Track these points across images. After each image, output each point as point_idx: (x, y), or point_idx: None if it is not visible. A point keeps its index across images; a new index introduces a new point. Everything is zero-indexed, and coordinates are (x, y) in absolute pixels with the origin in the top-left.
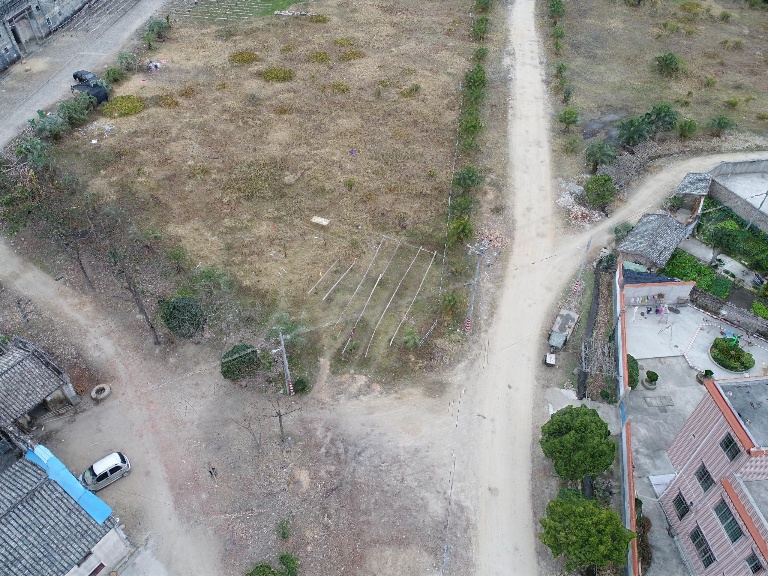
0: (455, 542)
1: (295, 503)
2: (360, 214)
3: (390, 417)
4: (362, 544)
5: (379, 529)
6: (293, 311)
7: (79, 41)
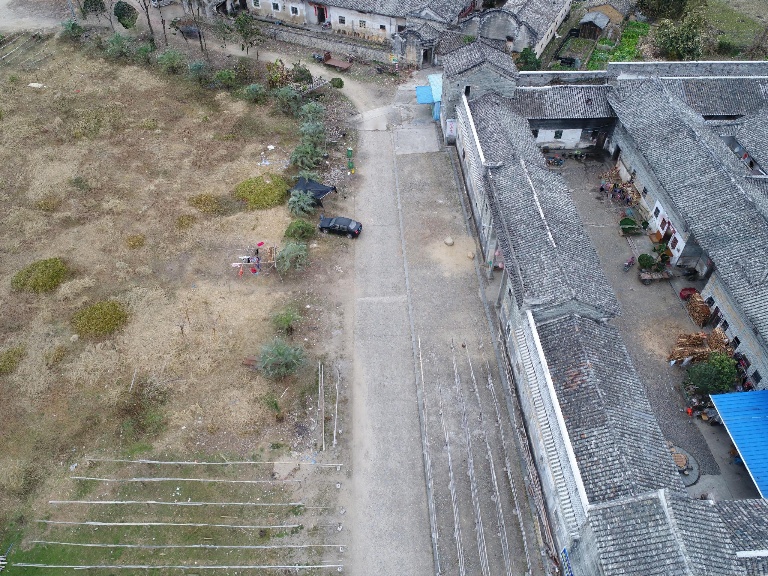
0: (18, 2)
1: (82, 6)
2: (0, 103)
3: (29, 24)
4: (56, 1)
5: (48, 3)
6: (72, 53)
7: (437, 331)
